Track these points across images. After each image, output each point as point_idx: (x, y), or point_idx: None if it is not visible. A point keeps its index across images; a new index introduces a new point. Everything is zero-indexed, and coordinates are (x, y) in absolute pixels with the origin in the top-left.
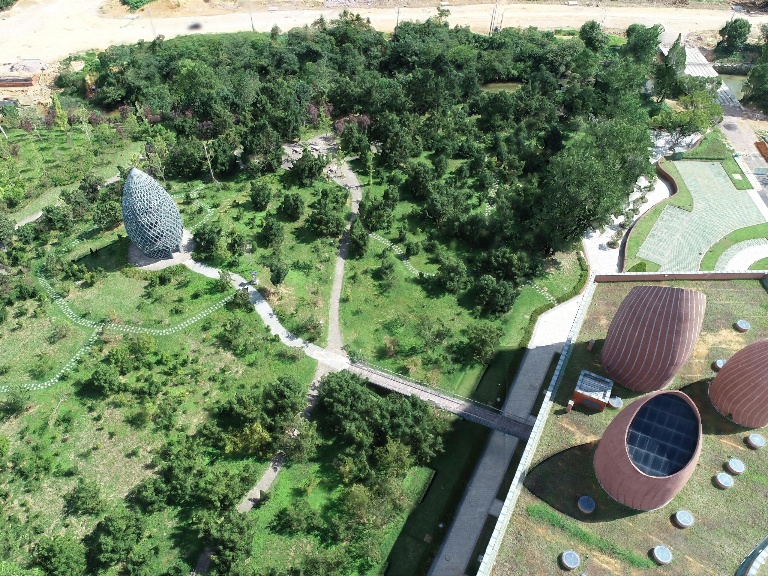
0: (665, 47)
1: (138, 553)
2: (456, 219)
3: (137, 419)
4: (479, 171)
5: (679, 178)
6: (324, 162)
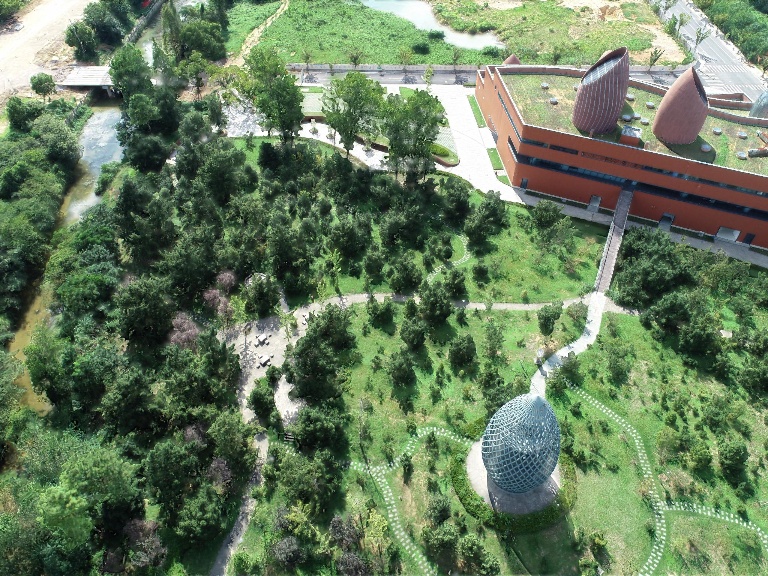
0: (61, 81)
1: None
2: (416, 213)
3: None
4: (310, 208)
5: (307, 113)
6: (334, 306)
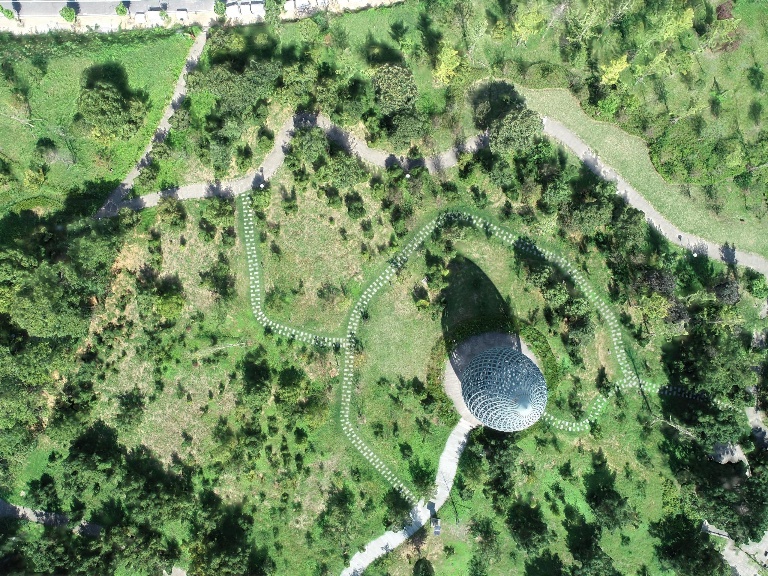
0: None
1: (85, 481)
2: None
3: (222, 433)
4: None
5: None
6: None
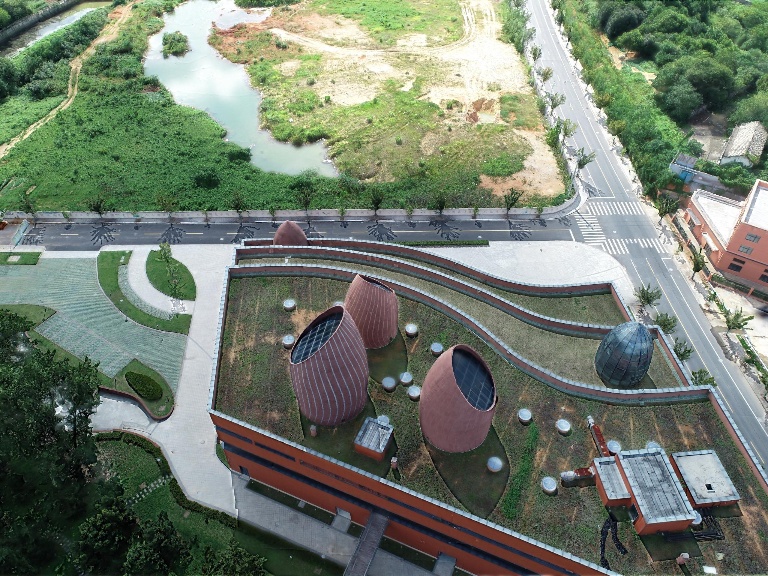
0: None
1: None
2: None
3: None
4: None
5: None
6: None
